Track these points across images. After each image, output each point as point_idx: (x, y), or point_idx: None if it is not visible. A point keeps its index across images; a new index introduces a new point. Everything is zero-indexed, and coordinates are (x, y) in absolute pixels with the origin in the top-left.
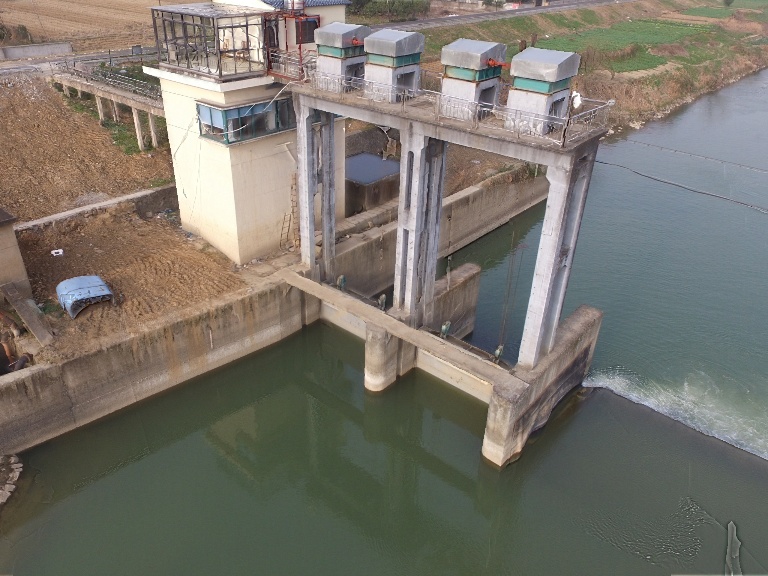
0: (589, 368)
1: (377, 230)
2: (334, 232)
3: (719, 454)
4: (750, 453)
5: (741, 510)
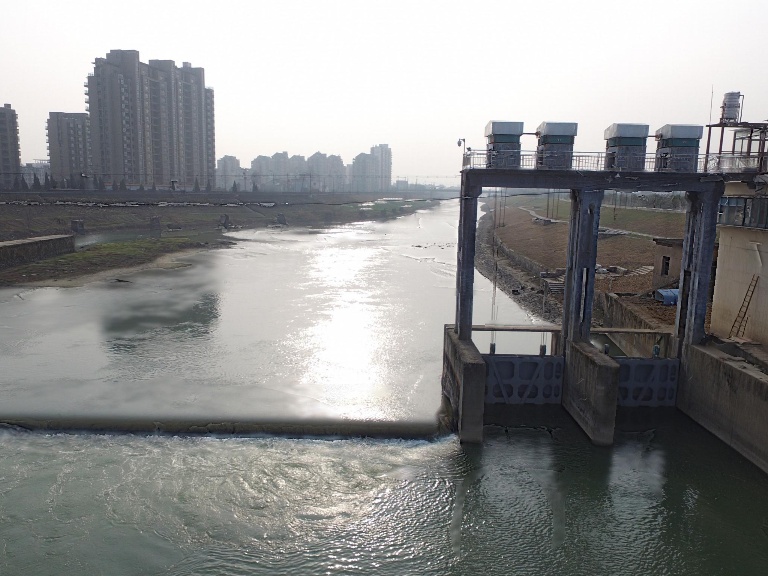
0: (472, 462)
1: (749, 367)
2: (694, 318)
3: (329, 424)
4: (308, 426)
5: (307, 409)
